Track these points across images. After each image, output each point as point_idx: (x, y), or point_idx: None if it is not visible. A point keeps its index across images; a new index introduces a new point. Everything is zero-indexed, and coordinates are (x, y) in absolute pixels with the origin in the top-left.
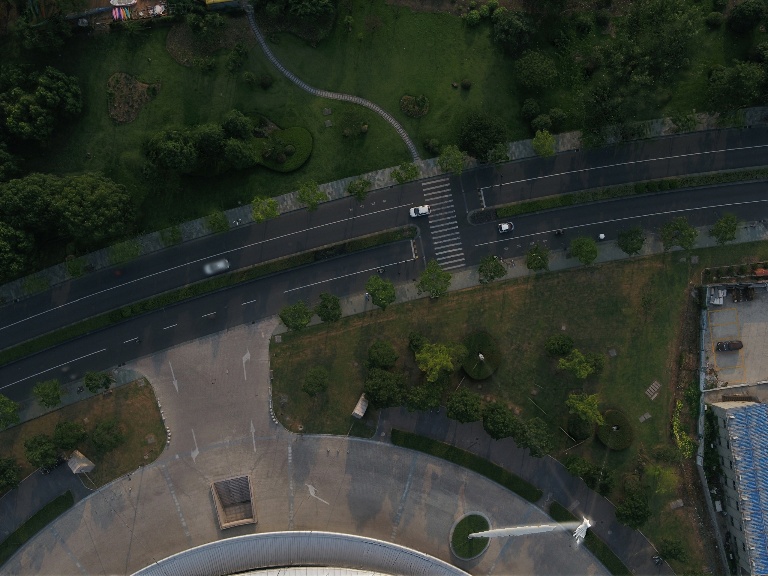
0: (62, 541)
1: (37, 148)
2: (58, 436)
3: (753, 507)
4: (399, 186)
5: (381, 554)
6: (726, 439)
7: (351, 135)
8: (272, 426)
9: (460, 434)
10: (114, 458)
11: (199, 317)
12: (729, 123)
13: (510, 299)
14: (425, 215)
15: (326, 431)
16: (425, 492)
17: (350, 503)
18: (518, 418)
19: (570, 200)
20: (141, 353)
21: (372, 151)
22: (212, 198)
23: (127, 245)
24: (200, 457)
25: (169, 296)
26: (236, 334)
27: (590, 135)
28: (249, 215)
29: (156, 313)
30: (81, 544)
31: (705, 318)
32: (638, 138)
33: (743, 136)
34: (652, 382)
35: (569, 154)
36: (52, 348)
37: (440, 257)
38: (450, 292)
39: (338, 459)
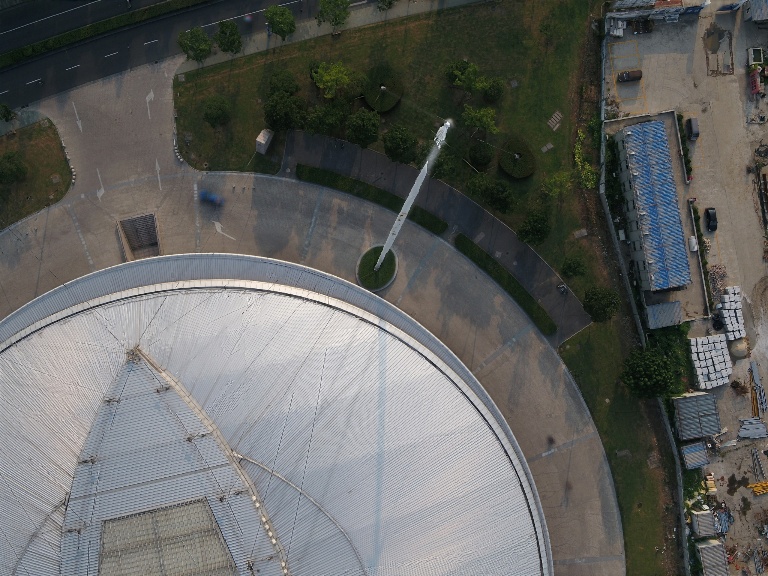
0: None
1: None
2: None
3: (651, 222)
4: None
5: (284, 274)
6: (625, 159)
7: None
8: (177, 164)
9: (365, 169)
10: (19, 198)
11: (101, 57)
12: None
13: (412, 34)
14: None
15: (231, 168)
16: (331, 226)
17: (256, 238)
18: None
19: None
20: (44, 94)
21: None
22: None
23: None
24: (106, 196)
25: (70, 35)
26: (139, 74)
27: None
28: None
29: (58, 54)
30: None
31: (604, 46)
32: None
33: None
34: (554, 113)
35: None
36: None
37: None
38: (352, 29)
39: (244, 195)
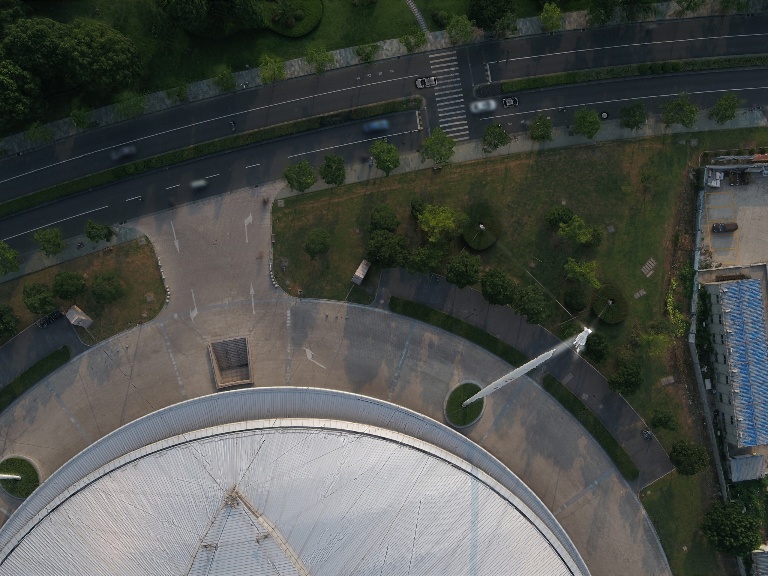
0: (57, 396)
1: (46, 2)
2: (58, 283)
3: (742, 379)
4: (407, 57)
5: (376, 412)
6: (718, 314)
7: (361, 4)
8: (272, 289)
9: (458, 304)
10: (112, 315)
11: (203, 178)
12: (732, 9)
13: (512, 173)
14: (431, 87)
15: (325, 296)
16: (421, 360)
17: (347, 368)
18: (516, 290)
19: (575, 78)
20: (143, 212)
21: (381, 21)
22: (220, 60)
23: (133, 103)
24: (199, 317)
25: (173, 155)
26: (239, 197)
27: (597, 11)
28: (256, 79)
29: (160, 172)
30: (76, 399)
31: (702, 198)
32: (643, 20)
33: (745, 24)
34: (648, 260)
35: (575, 33)
36: (53, 203)
37: (445, 129)
38: (453, 164)
39: (336, 324)
